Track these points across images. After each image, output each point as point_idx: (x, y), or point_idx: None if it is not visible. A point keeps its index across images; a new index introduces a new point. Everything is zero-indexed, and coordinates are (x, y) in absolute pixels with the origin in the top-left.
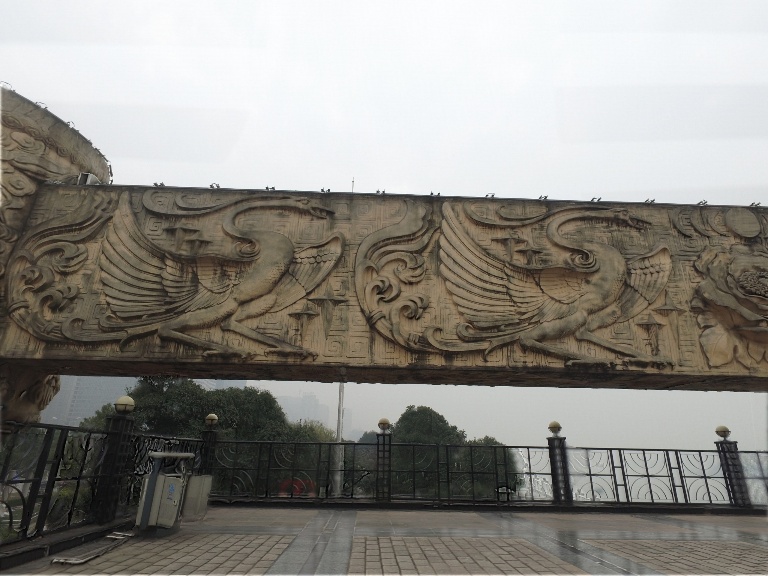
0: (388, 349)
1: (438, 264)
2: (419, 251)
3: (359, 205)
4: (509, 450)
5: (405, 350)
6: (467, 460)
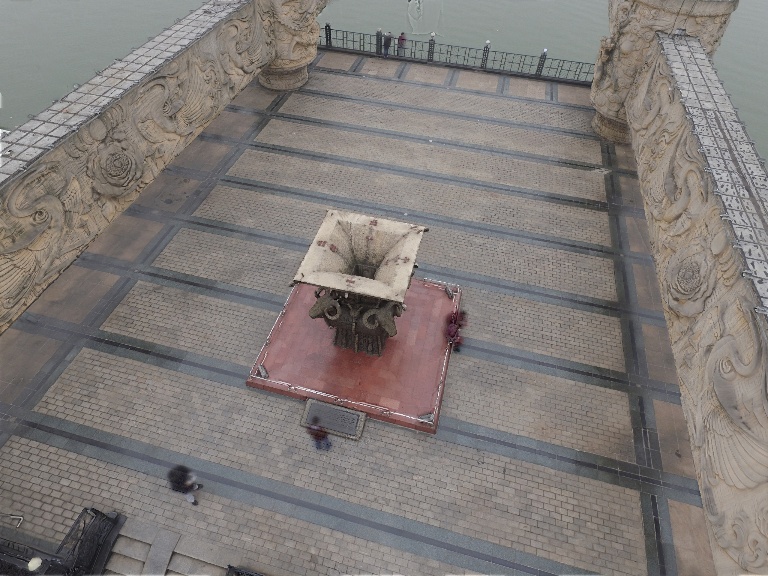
0: None
1: None
2: None
3: None
4: None
5: None
6: None
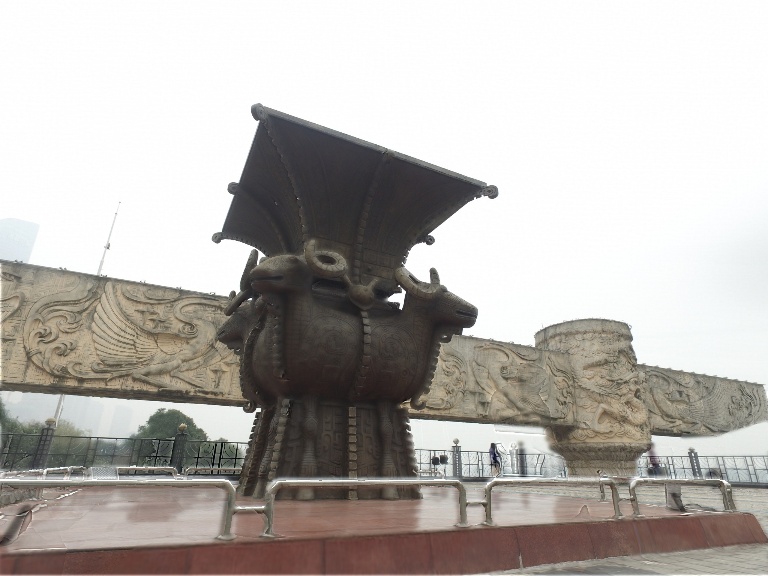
0: (38, 373)
1: (91, 322)
2: (79, 312)
3: (43, 275)
4: (145, 441)
5: (50, 375)
6: (112, 447)
